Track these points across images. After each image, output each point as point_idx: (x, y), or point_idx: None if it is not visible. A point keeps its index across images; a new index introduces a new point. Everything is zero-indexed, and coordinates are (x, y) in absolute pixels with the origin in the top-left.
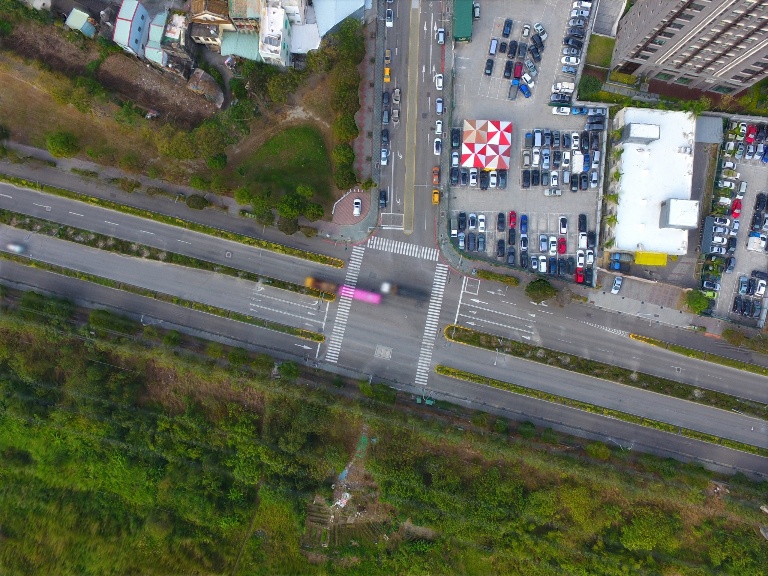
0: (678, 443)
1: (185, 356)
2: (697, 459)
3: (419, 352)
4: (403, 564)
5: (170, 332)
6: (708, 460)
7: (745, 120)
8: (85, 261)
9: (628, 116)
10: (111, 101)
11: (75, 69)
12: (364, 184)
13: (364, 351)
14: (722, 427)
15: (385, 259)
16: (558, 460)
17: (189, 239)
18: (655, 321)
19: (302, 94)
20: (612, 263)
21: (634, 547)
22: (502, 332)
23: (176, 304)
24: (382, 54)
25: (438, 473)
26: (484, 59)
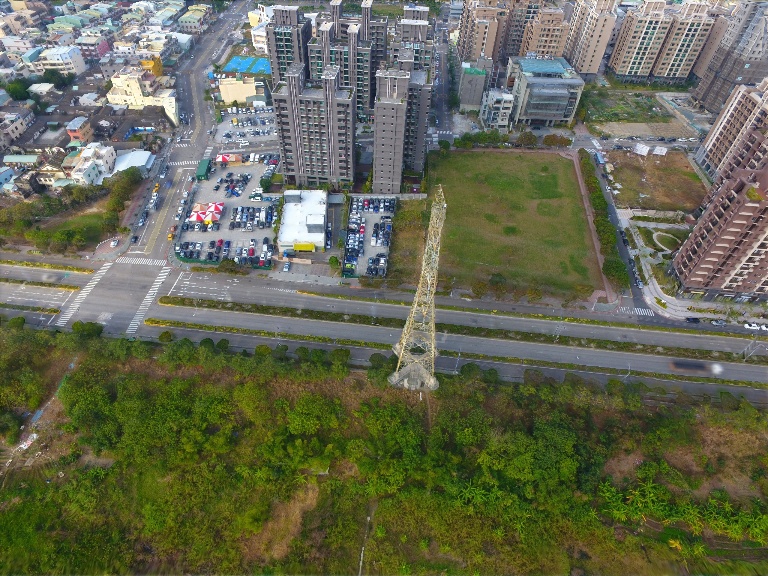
0: None
1: None
2: (351, 359)
3: (135, 314)
4: (69, 495)
5: None
6: (360, 359)
7: (361, 198)
8: None
9: None
10: None
11: None
12: None
13: (90, 317)
14: (368, 337)
15: (126, 267)
16: None
17: None
18: (315, 284)
19: (99, 203)
20: None
21: (298, 428)
22: (203, 297)
23: None
24: None
25: (123, 386)
26: None
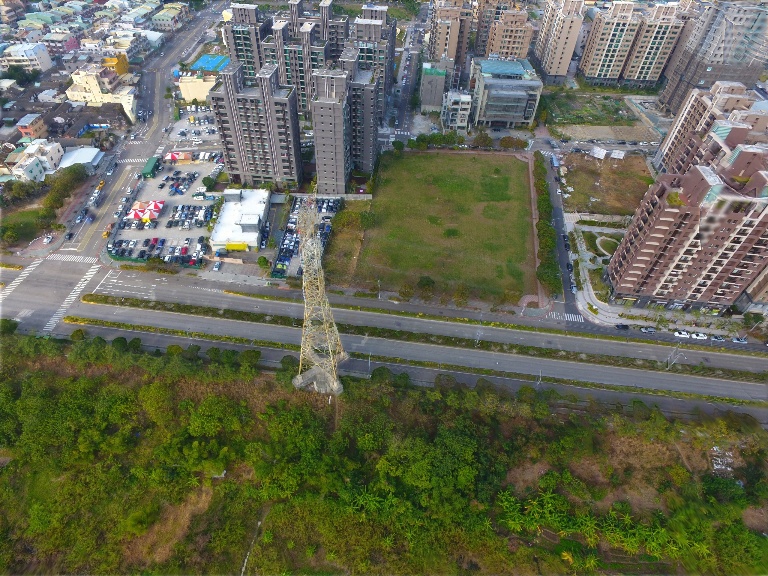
0: None
1: None
2: (266, 361)
3: (56, 311)
4: None
5: None
6: (275, 361)
7: (306, 197)
8: None
9: None
10: None
11: None
12: (54, 224)
13: (10, 313)
14: (287, 338)
15: (56, 264)
16: None
17: None
18: (244, 284)
19: (41, 199)
20: None
21: (197, 430)
22: (127, 295)
23: None
24: None
25: (28, 384)
26: None
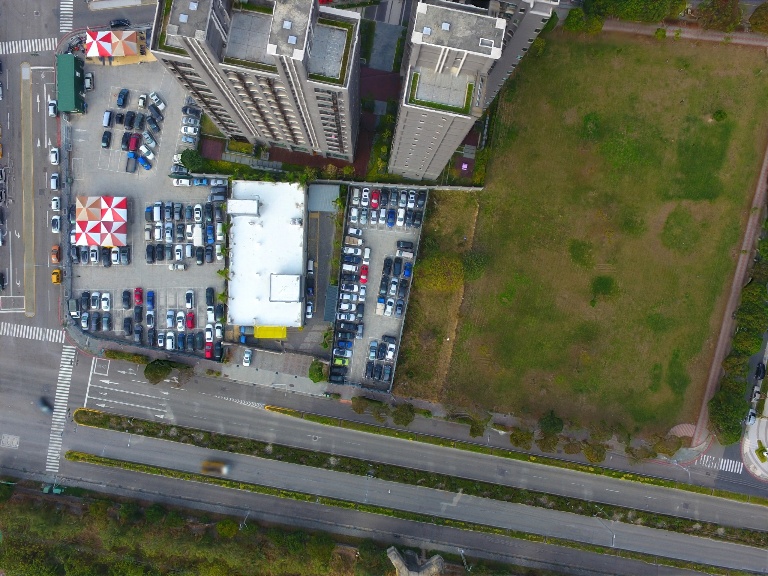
0: (318, 511)
1: None
2: (337, 526)
3: (48, 439)
4: None
5: None
6: (348, 526)
7: (367, 185)
8: None
9: (239, 188)
10: None
11: None
12: None
13: None
14: (360, 492)
15: (7, 344)
16: (179, 544)
17: None
18: (291, 391)
19: None
20: (240, 336)
21: None
22: (134, 412)
23: None
24: None
25: (67, 564)
26: (102, 131)
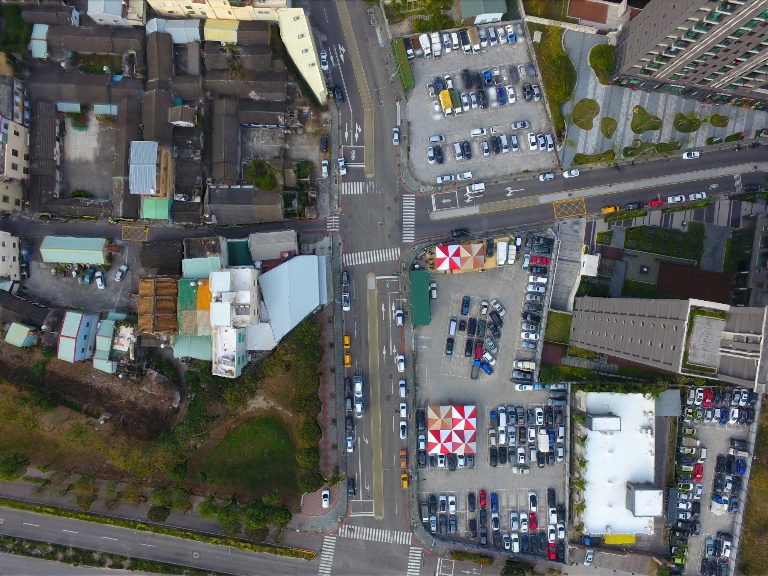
0: None
1: None
2: None
3: None
4: None
5: None
6: None
7: (701, 386)
8: (44, 574)
9: (589, 398)
10: (60, 404)
11: (19, 374)
12: (331, 484)
13: None
14: None
15: (358, 547)
16: None
17: (153, 542)
18: None
19: (261, 383)
20: (583, 537)
21: None
22: None
23: None
24: (341, 338)
25: None
26: (444, 337)
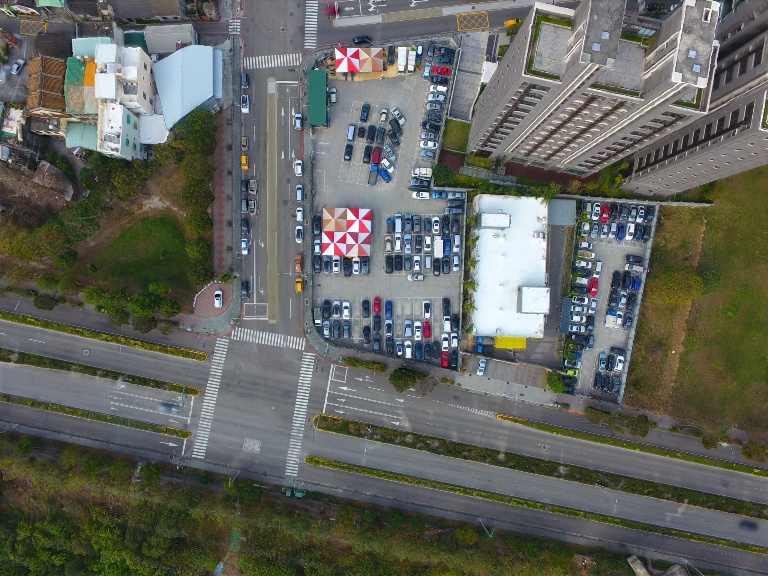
0: (546, 519)
1: (43, 461)
2: (565, 534)
3: (288, 443)
4: None
5: (21, 440)
6: (576, 534)
7: (599, 200)
8: None
9: (483, 202)
10: None
11: None
12: (221, 278)
13: (232, 445)
14: (587, 501)
15: (250, 350)
16: (425, 549)
17: (43, 338)
18: (521, 400)
19: (158, 183)
20: (476, 346)
21: None
22: (371, 419)
23: (31, 407)
24: (239, 141)
25: (309, 566)
26: (343, 144)
